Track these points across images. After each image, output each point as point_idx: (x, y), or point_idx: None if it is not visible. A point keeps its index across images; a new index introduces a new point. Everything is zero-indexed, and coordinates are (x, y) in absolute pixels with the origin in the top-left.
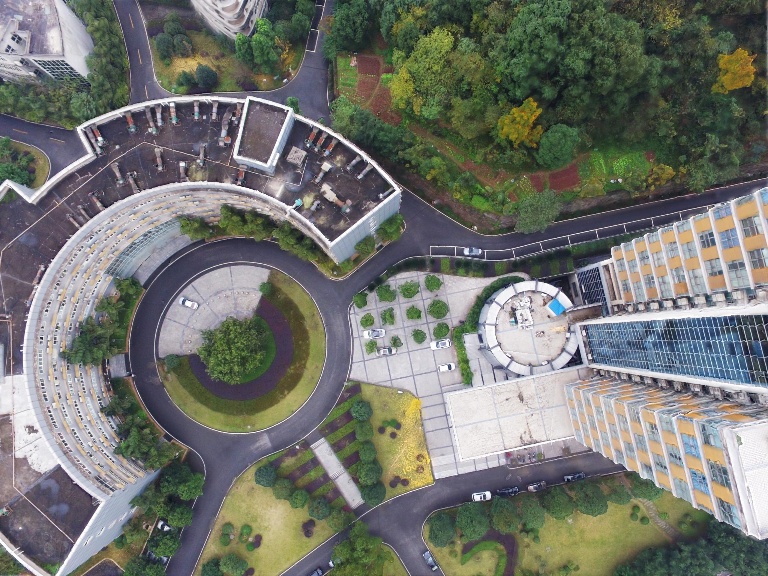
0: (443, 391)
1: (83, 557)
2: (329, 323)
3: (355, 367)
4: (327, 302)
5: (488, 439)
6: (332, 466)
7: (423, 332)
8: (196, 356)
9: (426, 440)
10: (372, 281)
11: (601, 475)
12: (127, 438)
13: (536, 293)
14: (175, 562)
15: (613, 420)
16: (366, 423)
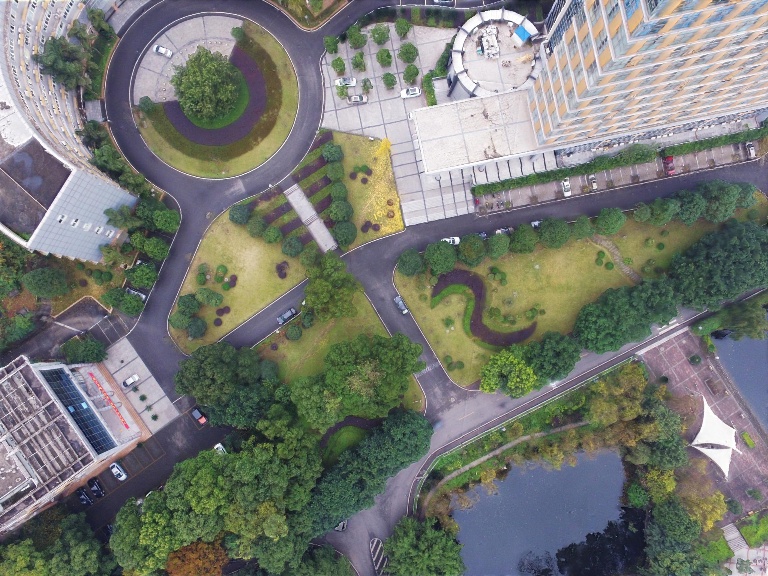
0: (413, 139)
1: (58, 243)
2: (301, 73)
3: (327, 116)
4: (299, 53)
5: (453, 153)
6: (305, 212)
7: (393, 75)
8: (170, 103)
9: (396, 186)
10: (343, 31)
11: (567, 222)
12: (101, 147)
13: (503, 24)
14: (153, 301)
15: (565, 59)
16: (337, 162)
